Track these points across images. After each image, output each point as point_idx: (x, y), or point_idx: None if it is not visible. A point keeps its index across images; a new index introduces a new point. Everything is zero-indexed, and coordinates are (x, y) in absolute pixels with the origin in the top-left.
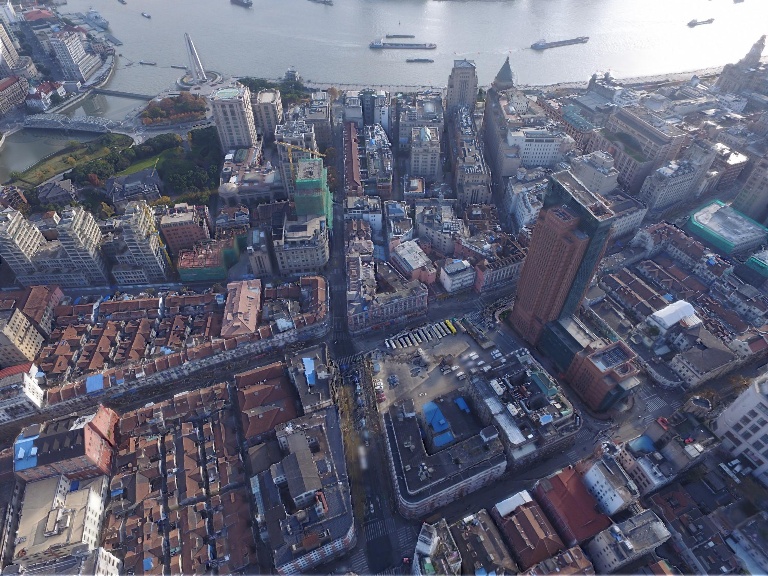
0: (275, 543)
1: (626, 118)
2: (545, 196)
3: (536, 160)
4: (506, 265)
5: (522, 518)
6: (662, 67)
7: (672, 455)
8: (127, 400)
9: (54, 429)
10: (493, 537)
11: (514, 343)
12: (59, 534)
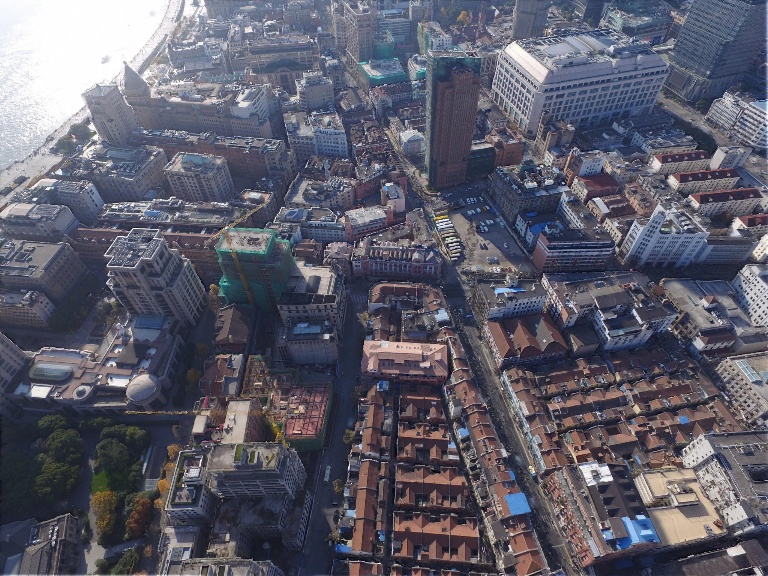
0: (663, 313)
1: (261, 51)
2: (432, 76)
3: (263, 117)
4: (400, 163)
5: (611, 203)
6: (141, 29)
7: (565, 141)
8: (517, 483)
9: (610, 504)
10: (625, 216)
11: (460, 191)
12: (693, 490)
